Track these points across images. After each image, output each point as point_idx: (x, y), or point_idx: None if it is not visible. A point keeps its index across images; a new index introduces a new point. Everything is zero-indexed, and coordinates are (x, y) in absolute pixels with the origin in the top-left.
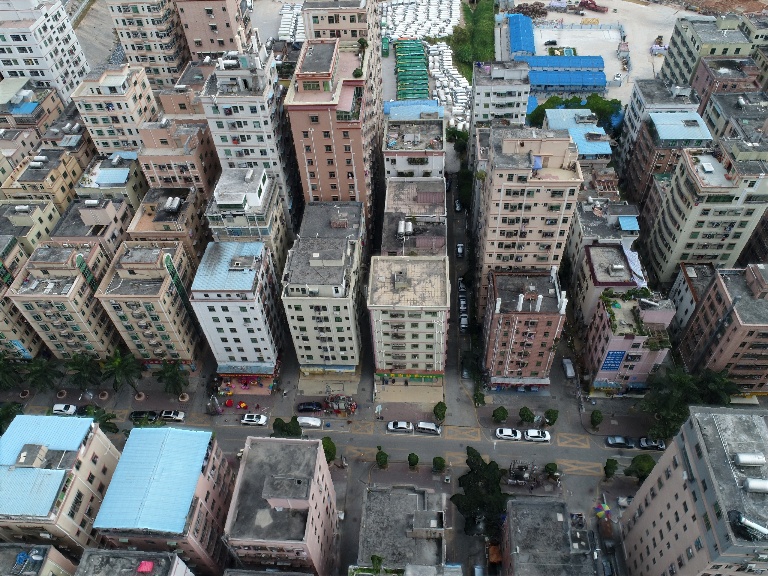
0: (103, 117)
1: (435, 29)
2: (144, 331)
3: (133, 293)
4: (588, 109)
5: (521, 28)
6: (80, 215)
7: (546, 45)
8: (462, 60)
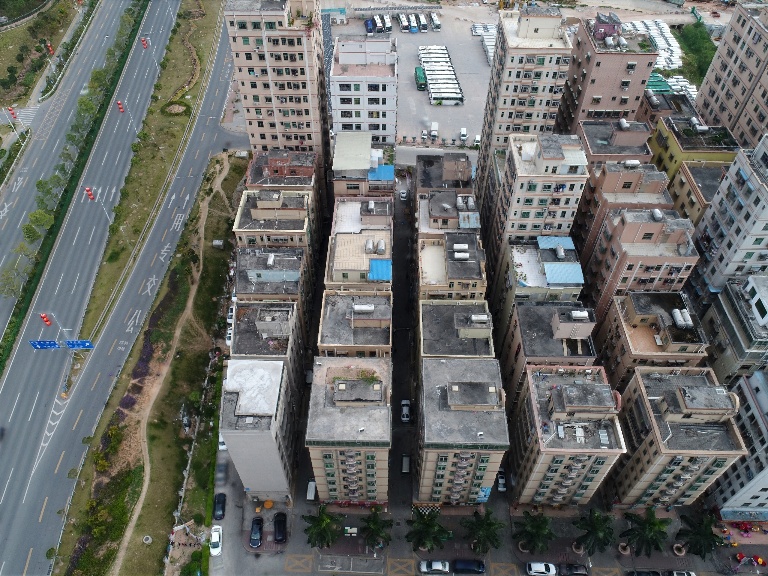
0: (543, 199)
1: (662, 60)
2: (675, 482)
3: (698, 445)
4: None
5: None
6: (557, 328)
7: None
8: None
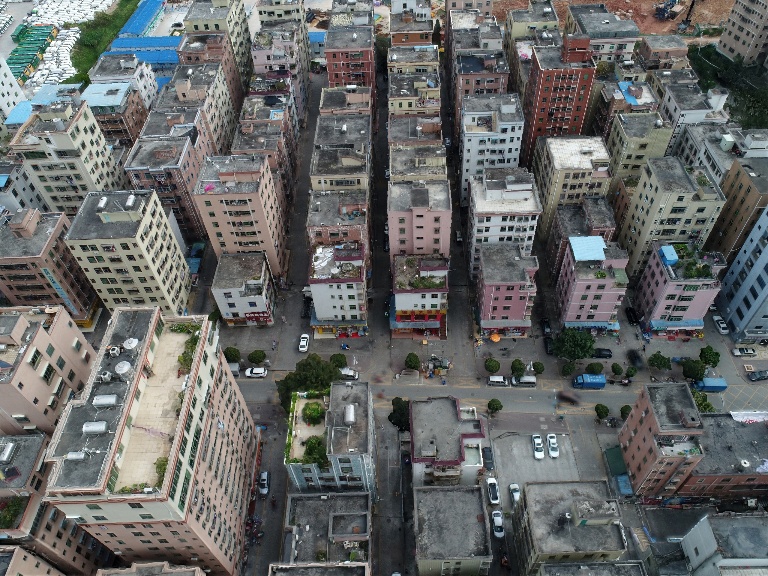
0: None
1: (77, 15)
2: None
3: None
4: (80, 84)
5: (142, 12)
6: None
7: (172, 27)
8: (84, 44)
